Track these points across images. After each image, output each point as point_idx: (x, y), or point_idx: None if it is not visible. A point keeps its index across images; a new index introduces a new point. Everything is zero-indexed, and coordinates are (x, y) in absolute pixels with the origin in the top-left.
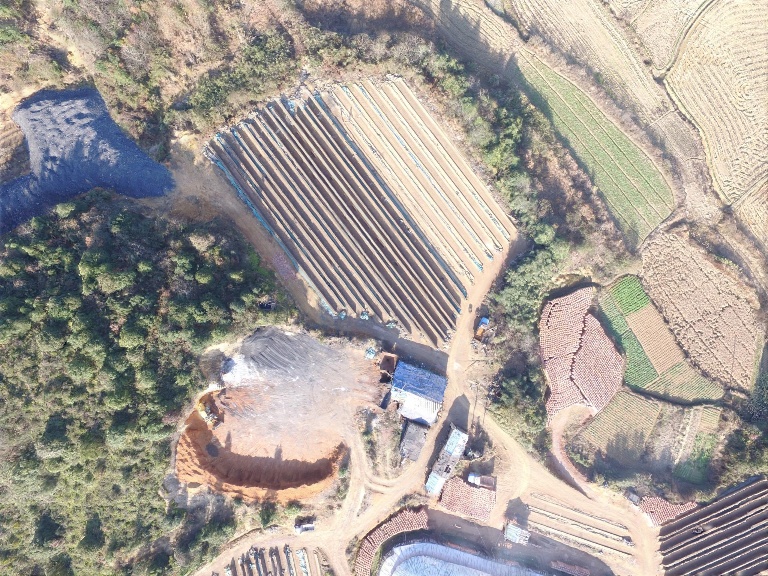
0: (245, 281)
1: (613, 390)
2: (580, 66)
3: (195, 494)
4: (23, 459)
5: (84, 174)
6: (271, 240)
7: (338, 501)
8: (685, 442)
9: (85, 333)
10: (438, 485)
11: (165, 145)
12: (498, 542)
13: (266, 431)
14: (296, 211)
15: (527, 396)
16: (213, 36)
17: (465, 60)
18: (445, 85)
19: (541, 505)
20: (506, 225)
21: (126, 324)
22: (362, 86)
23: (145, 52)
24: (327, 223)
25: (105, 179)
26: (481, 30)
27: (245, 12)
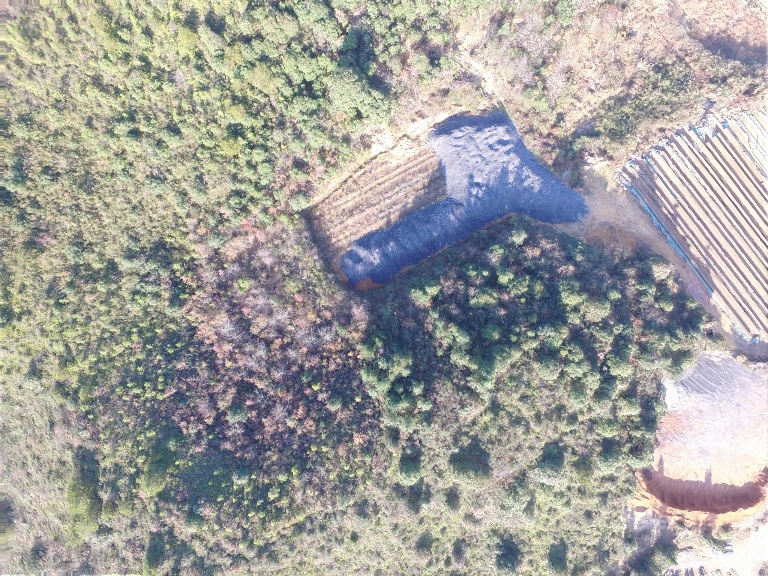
0: None
1: None
2: None
3: (641, 518)
4: (517, 486)
5: (506, 200)
6: (685, 266)
7: (765, 524)
8: None
9: (587, 362)
10: None
11: (577, 171)
12: None
13: (696, 455)
14: (711, 237)
15: None
16: (615, 63)
17: None
18: None
19: None
20: None
21: (611, 352)
22: (767, 114)
23: (558, 79)
24: None
25: (523, 205)
26: None
27: (637, 39)
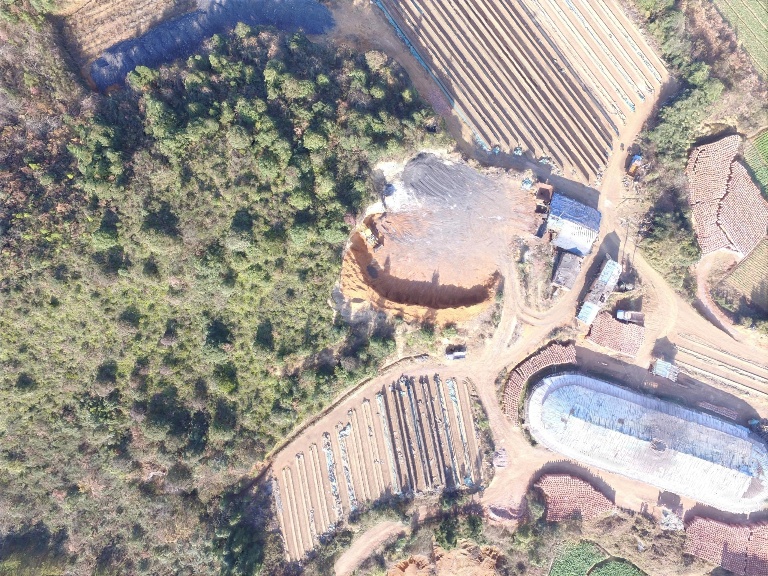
0: (412, 104)
1: (760, 236)
2: None
3: (358, 310)
4: (209, 253)
5: (250, 9)
6: (427, 77)
7: (493, 327)
8: None
9: (275, 130)
10: (592, 315)
11: None
12: (644, 381)
13: (424, 256)
14: (453, 49)
15: (682, 229)
16: None
17: None
18: None
19: (688, 345)
20: (658, 68)
21: (309, 128)
22: None
23: None
24: (482, 62)
25: (269, 16)
26: None
27: None
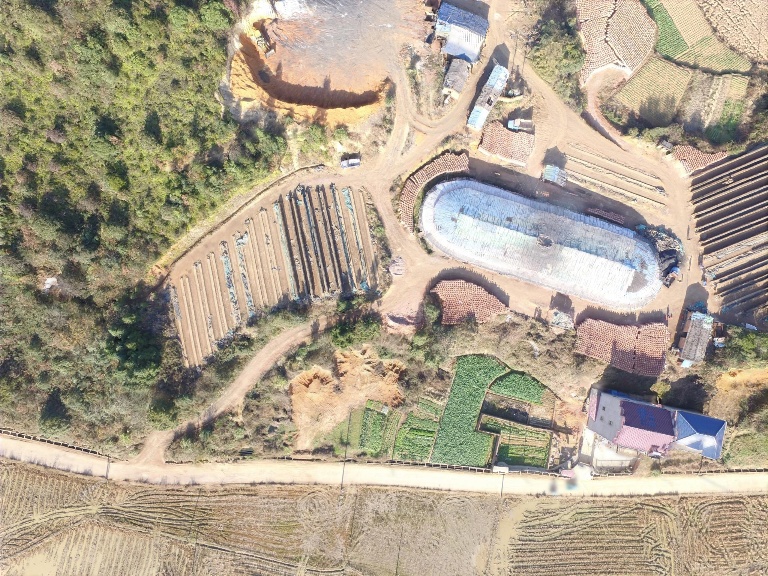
0: None
1: (646, 51)
2: None
3: (248, 109)
4: None
5: None
6: None
7: (384, 130)
8: (715, 107)
9: None
10: (480, 118)
11: None
12: (536, 190)
13: (316, 62)
14: None
15: (566, 34)
16: None
17: None
18: None
19: (577, 154)
20: None
21: None
22: None
23: None
24: None
25: None
26: None
27: None
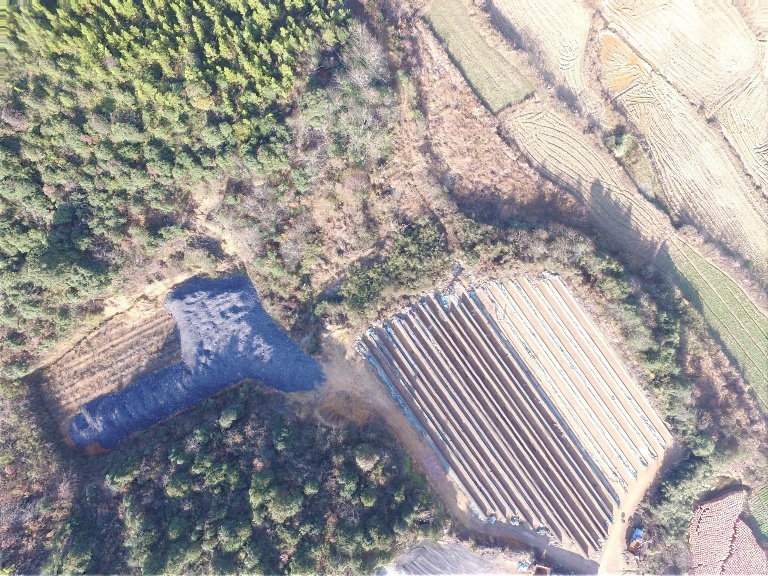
0: (405, 496)
1: None
2: (730, 253)
3: None
4: None
5: (237, 368)
6: (422, 440)
7: None
8: None
9: (260, 569)
10: None
11: (316, 337)
12: None
13: None
14: (449, 412)
15: None
16: (365, 224)
17: (617, 250)
18: (604, 287)
19: None
20: (662, 432)
21: (296, 554)
22: (517, 283)
23: (299, 243)
24: (479, 424)
25: (256, 372)
26: (632, 217)
27: (395, 196)
